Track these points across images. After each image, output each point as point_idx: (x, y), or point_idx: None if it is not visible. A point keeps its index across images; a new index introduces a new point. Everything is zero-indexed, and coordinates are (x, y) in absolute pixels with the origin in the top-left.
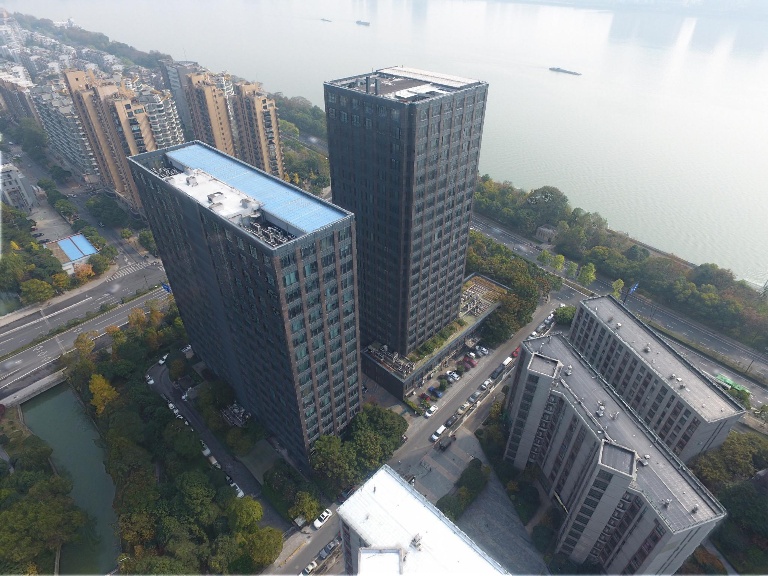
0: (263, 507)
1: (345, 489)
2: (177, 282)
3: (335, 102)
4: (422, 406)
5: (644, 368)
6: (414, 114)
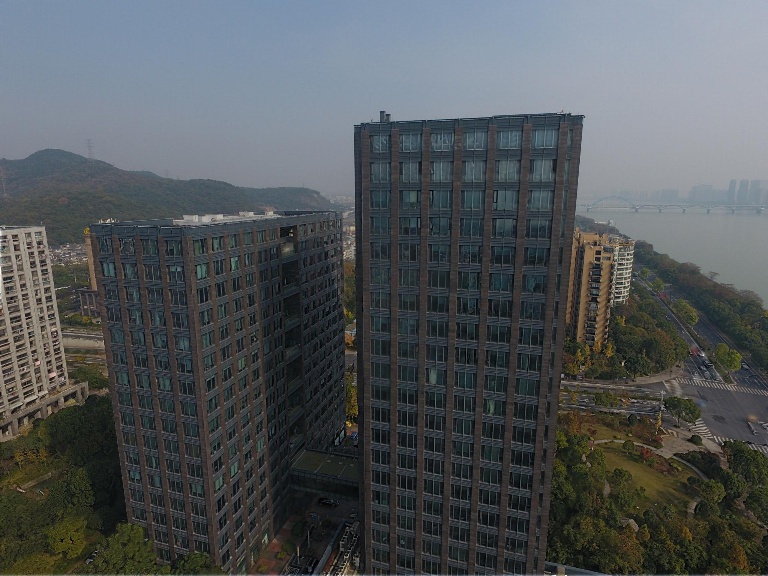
0: None
1: None
2: None
3: None
4: None
5: None
6: None
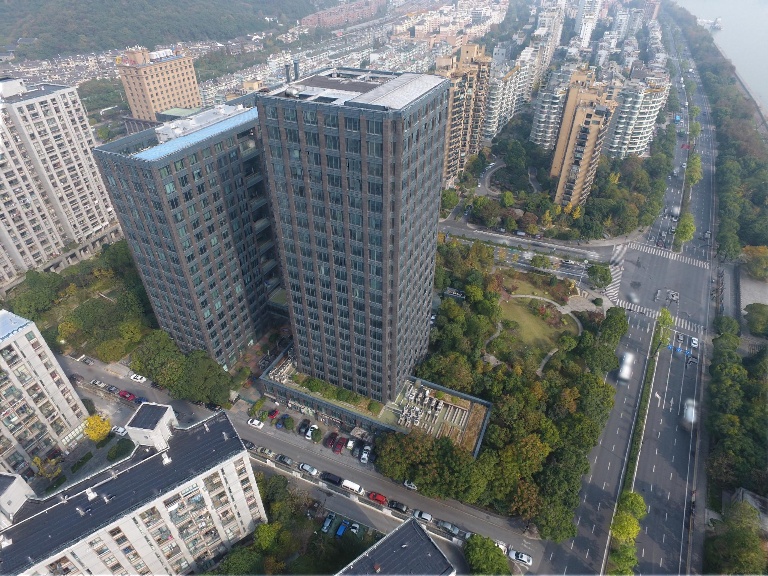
0: None
1: None
2: None
3: None
4: None
5: None
6: None
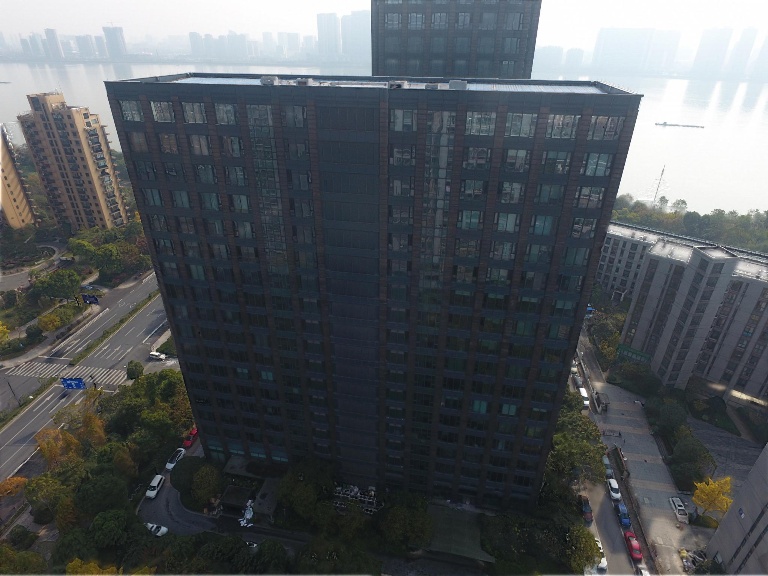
0: None
1: (582, 502)
2: (207, 317)
3: (400, 2)
4: None
5: None
6: None
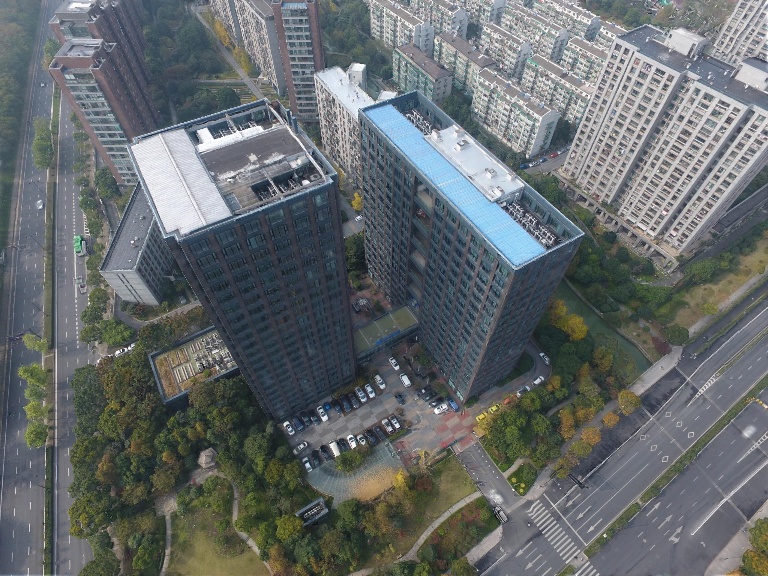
0: None
1: None
2: None
3: None
4: None
5: None
6: None
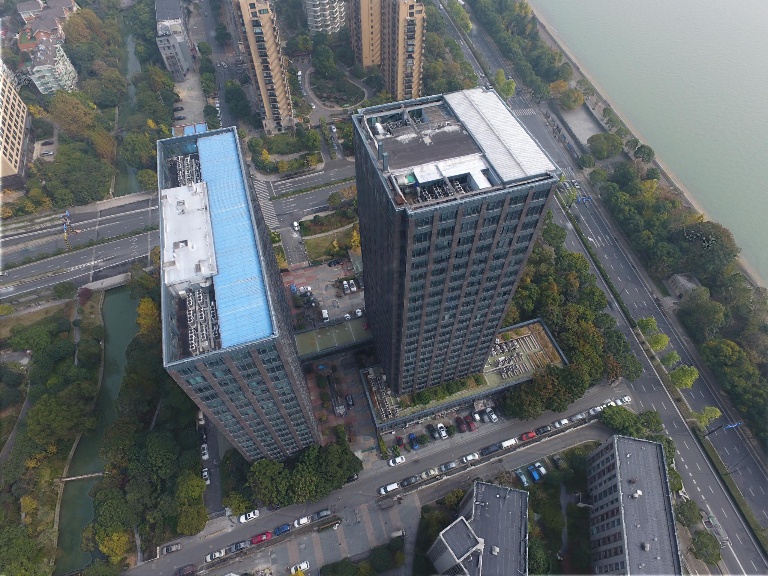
0: (216, 477)
1: None
2: None
3: None
4: (392, 451)
5: (624, 566)
6: (407, 221)
